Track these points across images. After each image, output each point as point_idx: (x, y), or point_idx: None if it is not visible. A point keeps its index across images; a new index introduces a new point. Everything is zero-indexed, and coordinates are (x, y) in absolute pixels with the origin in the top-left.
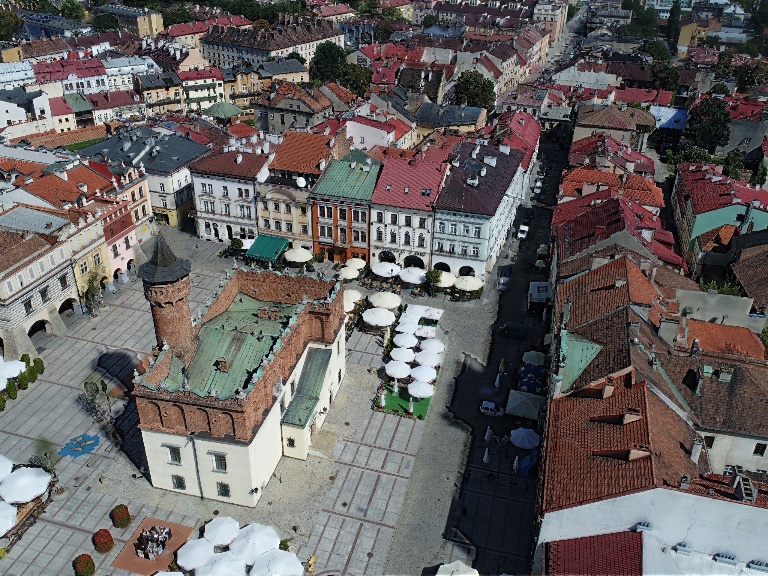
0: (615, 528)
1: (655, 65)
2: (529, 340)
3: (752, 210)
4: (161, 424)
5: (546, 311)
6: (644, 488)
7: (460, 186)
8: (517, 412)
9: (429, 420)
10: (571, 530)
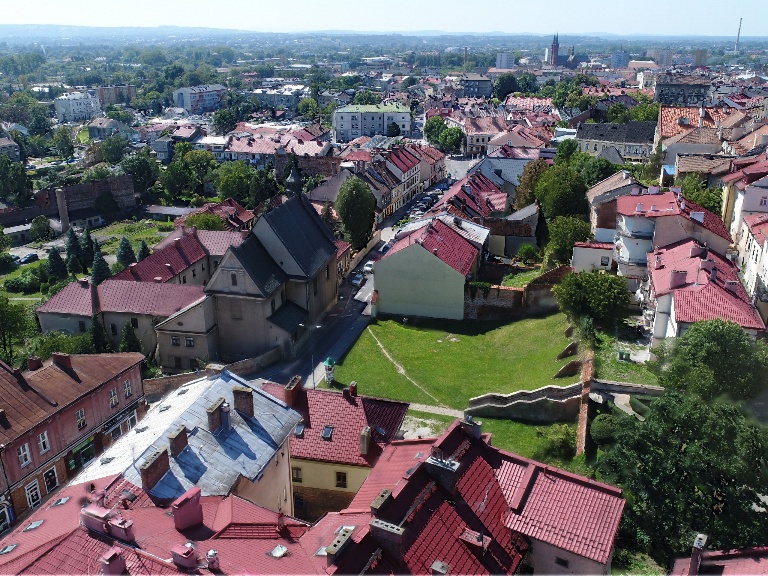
0: None
1: None
2: None
3: None
4: None
5: None
6: None
7: None
8: None
9: None
10: None
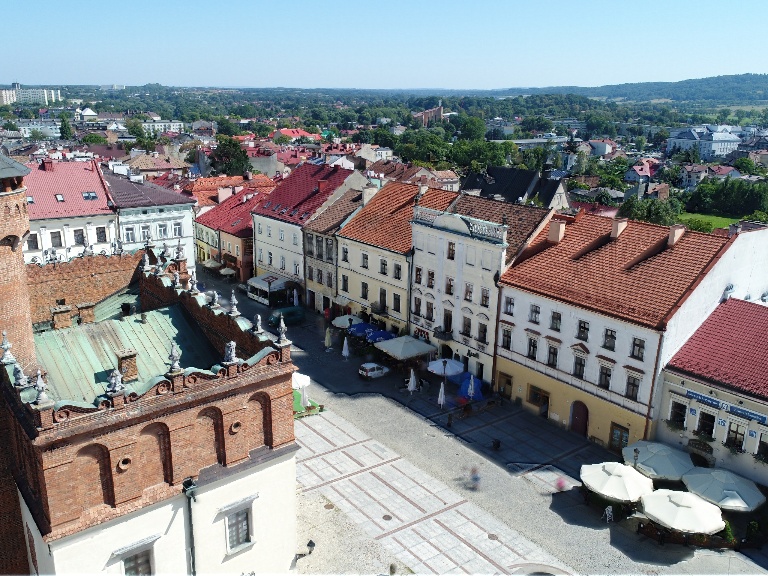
0: (711, 308)
1: (121, 144)
2: (307, 322)
3: (371, 180)
4: (104, 504)
5: (298, 291)
6: (730, 241)
7: (126, 184)
8: (410, 353)
9: (331, 408)
10: (683, 333)
